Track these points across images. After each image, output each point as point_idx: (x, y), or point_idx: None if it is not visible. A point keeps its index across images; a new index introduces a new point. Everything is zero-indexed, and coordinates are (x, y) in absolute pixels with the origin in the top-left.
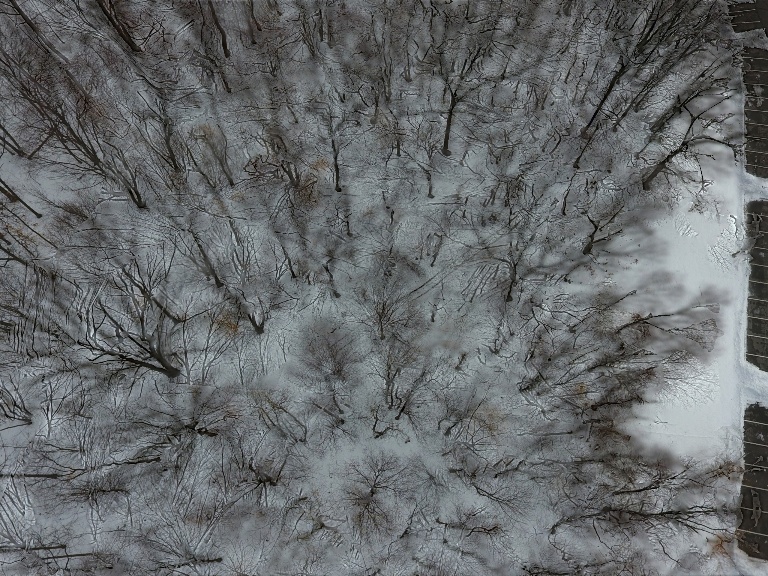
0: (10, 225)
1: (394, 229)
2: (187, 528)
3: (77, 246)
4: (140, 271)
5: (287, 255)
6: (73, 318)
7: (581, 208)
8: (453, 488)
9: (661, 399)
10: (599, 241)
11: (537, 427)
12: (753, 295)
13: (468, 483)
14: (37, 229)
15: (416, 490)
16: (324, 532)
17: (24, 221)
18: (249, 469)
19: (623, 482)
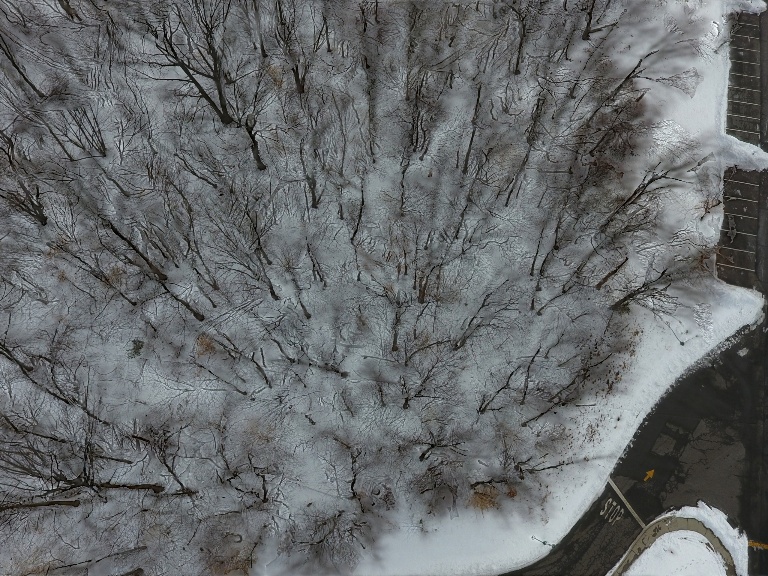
0: (82, 2)
1: (416, 15)
2: (242, 235)
3: (146, 1)
4: (204, 5)
5: (325, 19)
6: (149, 40)
7: (581, 5)
8: (470, 211)
9: (651, 154)
10: (596, 31)
11: (542, 164)
12: (733, 84)
13: (483, 208)
14: (105, 8)
15: (438, 211)
16: (359, 242)
17: (93, 2)
18: (300, 157)
19: (617, 205)
